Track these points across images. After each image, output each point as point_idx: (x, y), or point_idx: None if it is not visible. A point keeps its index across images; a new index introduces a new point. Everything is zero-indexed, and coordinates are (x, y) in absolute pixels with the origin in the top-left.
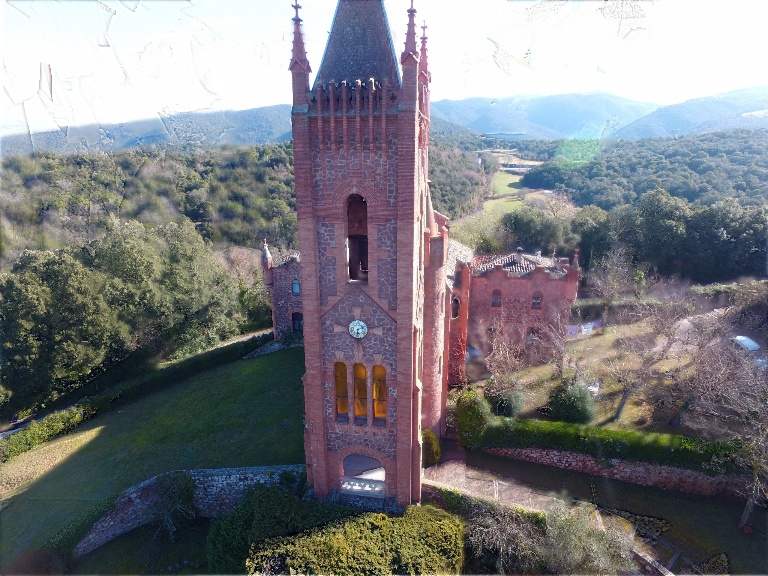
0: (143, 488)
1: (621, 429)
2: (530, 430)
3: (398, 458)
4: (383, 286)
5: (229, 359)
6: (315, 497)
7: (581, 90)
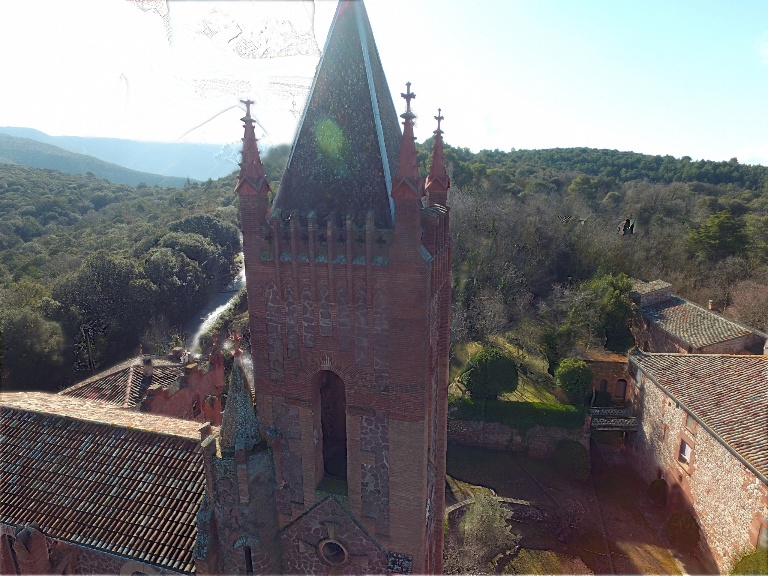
0: None
1: None
2: None
3: None
4: None
5: None
6: None
7: None
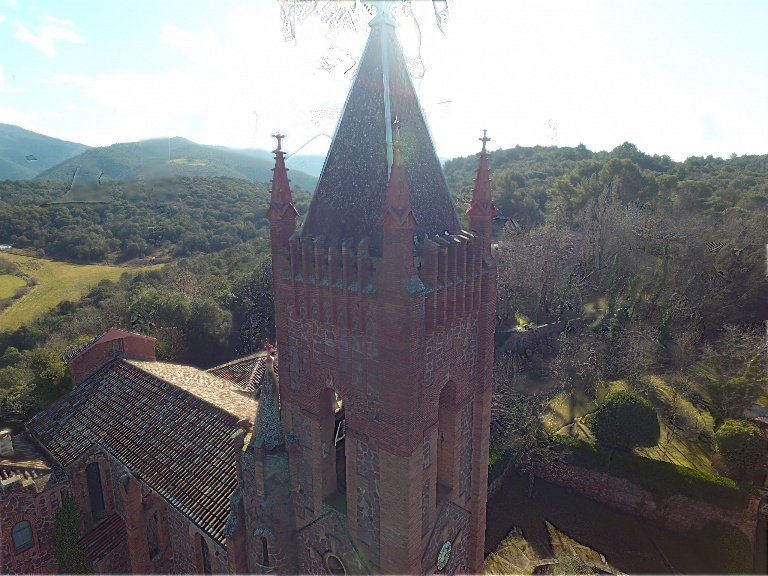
0: None
1: None
2: None
3: None
4: (462, 480)
5: None
6: None
7: (140, 152)
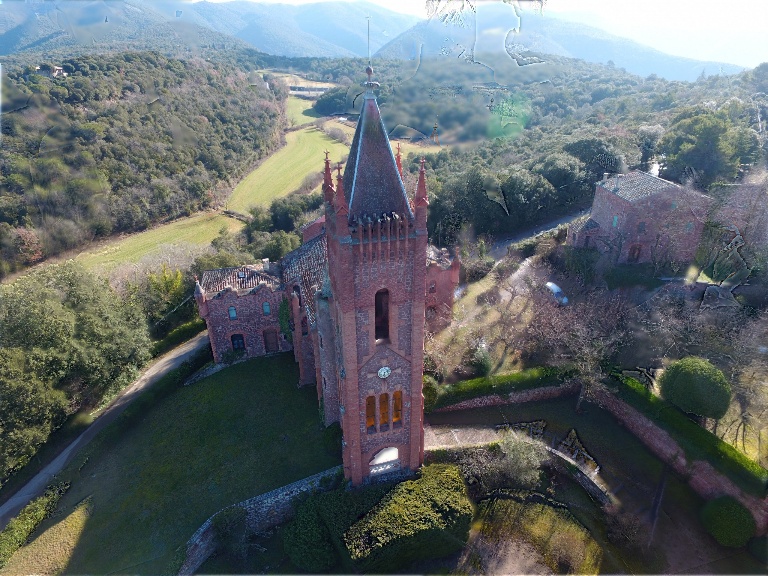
0: (203, 532)
1: (507, 370)
2: (463, 390)
3: (412, 443)
4: (401, 342)
5: (170, 390)
6: (354, 486)
7: (401, 66)
